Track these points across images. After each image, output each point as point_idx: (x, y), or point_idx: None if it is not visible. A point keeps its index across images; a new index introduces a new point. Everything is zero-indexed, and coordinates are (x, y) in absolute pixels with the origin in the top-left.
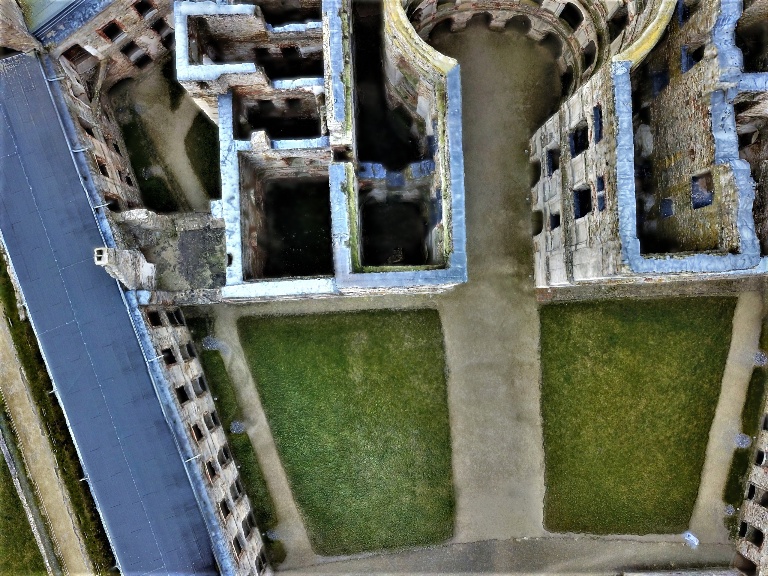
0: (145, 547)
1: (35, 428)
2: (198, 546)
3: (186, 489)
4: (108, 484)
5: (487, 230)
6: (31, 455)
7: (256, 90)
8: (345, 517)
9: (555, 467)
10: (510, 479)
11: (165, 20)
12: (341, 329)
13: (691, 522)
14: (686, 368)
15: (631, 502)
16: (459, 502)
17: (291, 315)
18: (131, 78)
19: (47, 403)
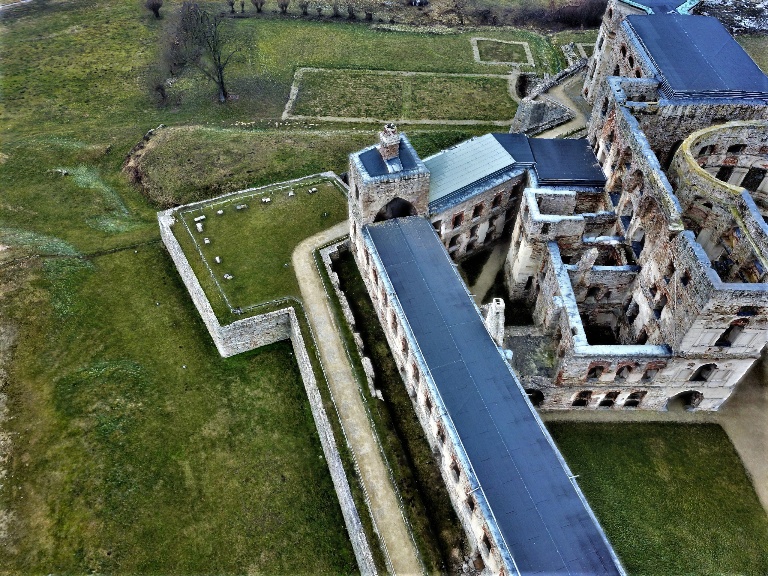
0: (545, 555)
1: (383, 485)
2: (599, 557)
3: (576, 500)
4: (501, 491)
5: None
6: (378, 510)
7: (569, 243)
8: None
9: None
10: None
11: (478, 227)
12: (638, 435)
13: None
14: None
15: None
16: None
17: (590, 422)
18: None
19: (394, 463)
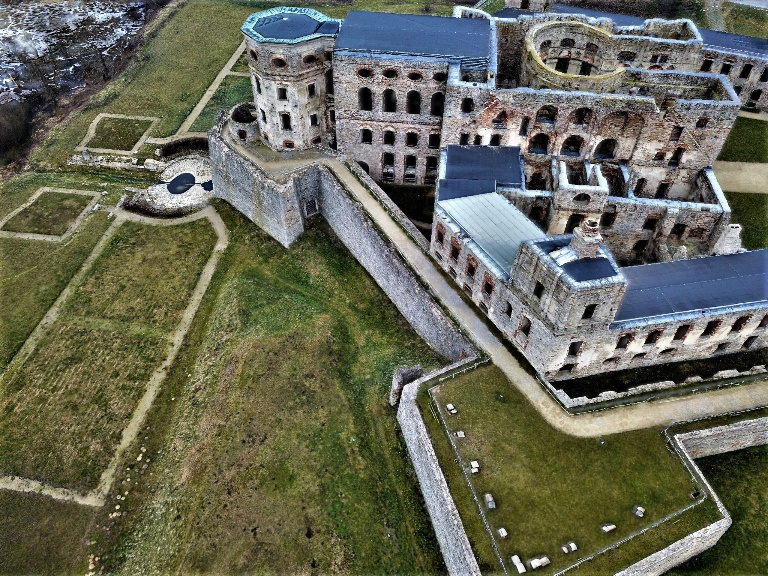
0: None
1: None
2: None
3: None
4: None
5: None
6: None
7: None
8: None
9: (765, 160)
10: None
11: None
12: None
13: None
14: None
15: None
16: None
17: None
18: None
19: None
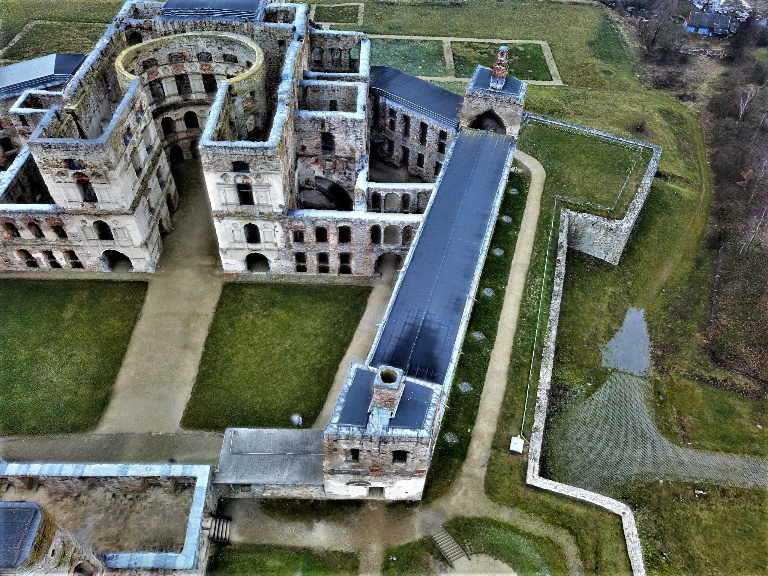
0: None
1: None
2: None
3: None
4: None
5: (200, 243)
6: None
7: None
8: (7, 408)
9: (204, 381)
10: (163, 388)
11: None
12: (71, 288)
13: (313, 428)
14: (327, 324)
15: (263, 410)
16: (112, 403)
17: (38, 279)
18: (3, 168)
19: None
